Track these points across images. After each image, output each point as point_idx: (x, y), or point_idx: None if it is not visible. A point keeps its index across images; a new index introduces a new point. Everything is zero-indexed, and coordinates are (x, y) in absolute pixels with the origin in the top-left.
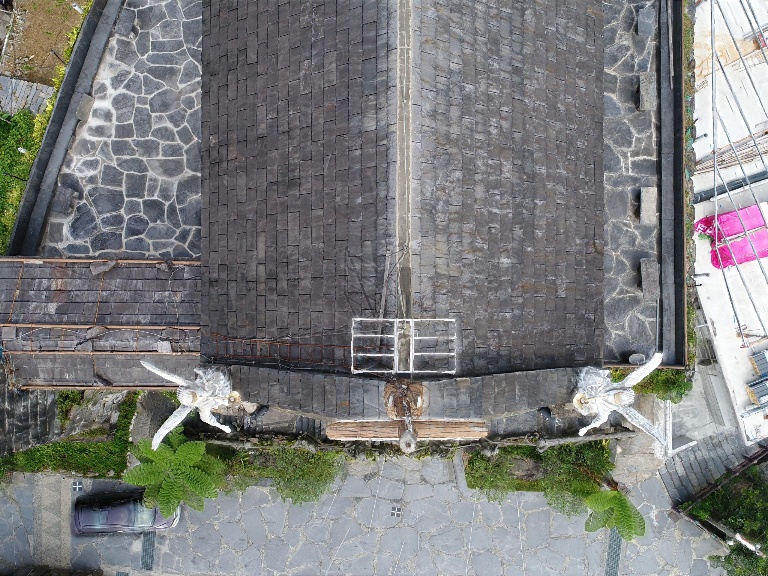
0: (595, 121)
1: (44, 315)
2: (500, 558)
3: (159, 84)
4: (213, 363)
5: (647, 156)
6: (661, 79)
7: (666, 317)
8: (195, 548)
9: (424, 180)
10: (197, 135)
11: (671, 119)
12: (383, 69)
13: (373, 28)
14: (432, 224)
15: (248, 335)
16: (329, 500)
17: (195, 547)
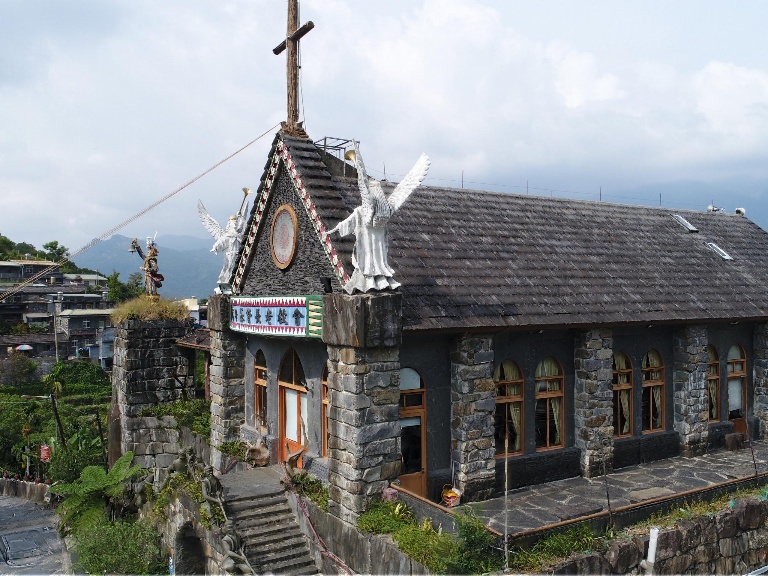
0: None
1: None
2: None
3: None
4: None
5: None
6: None
7: None
8: None
9: None
10: None
11: None
12: None
13: None
14: None
15: None
16: None
17: None
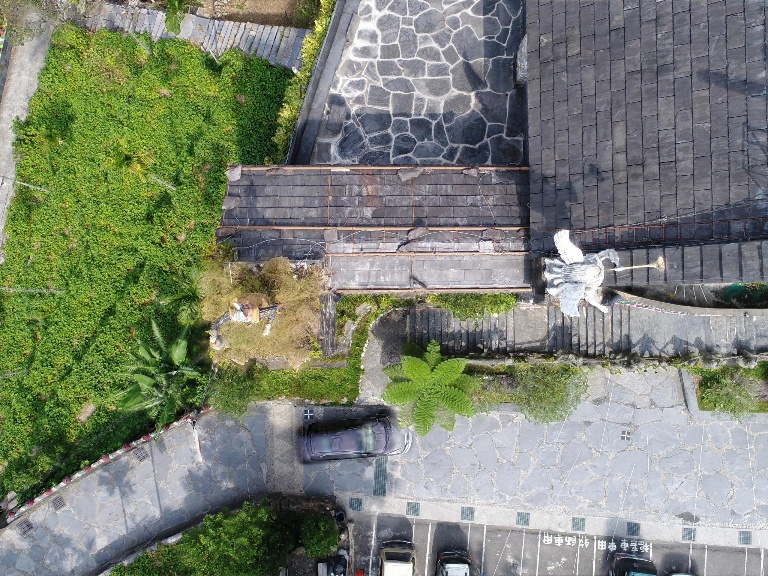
0: None
1: (361, 219)
2: (730, 479)
3: (424, 5)
4: None
5: None
6: None
7: None
8: (427, 473)
9: None
10: (462, 55)
11: None
12: None
13: None
14: None
15: (602, 224)
16: (559, 425)
17: (427, 472)
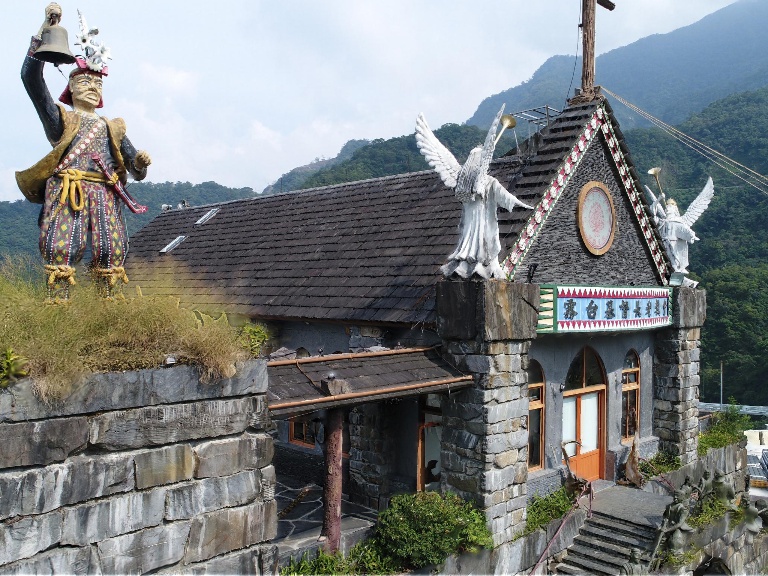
0: None
1: None
2: None
3: None
4: None
5: None
6: None
7: None
8: None
9: None
10: None
11: None
12: None
13: None
14: None
15: None
16: None
17: None
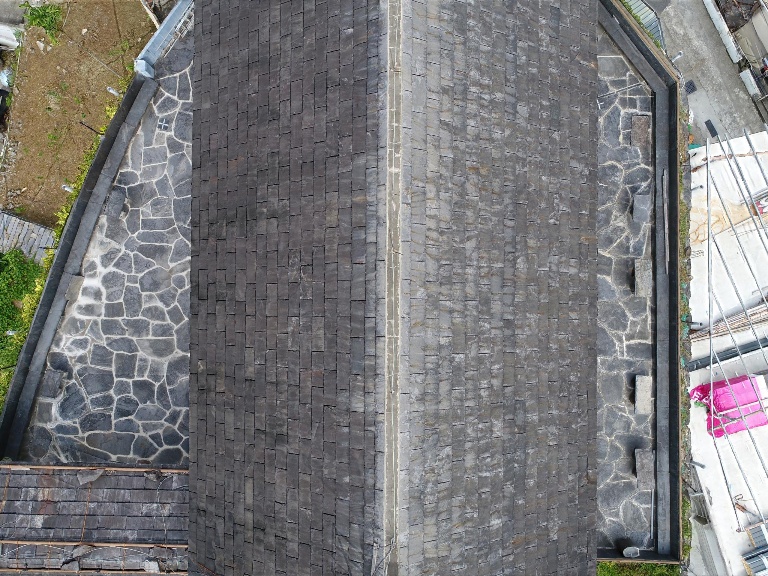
0: (588, 348)
1: (30, 529)
2: None
3: (149, 263)
4: None
5: (642, 340)
6: (656, 264)
7: (661, 506)
8: None
9: (412, 468)
10: (188, 315)
11: (666, 305)
12: (371, 353)
13: (361, 308)
14: (420, 510)
15: None
16: None
17: None
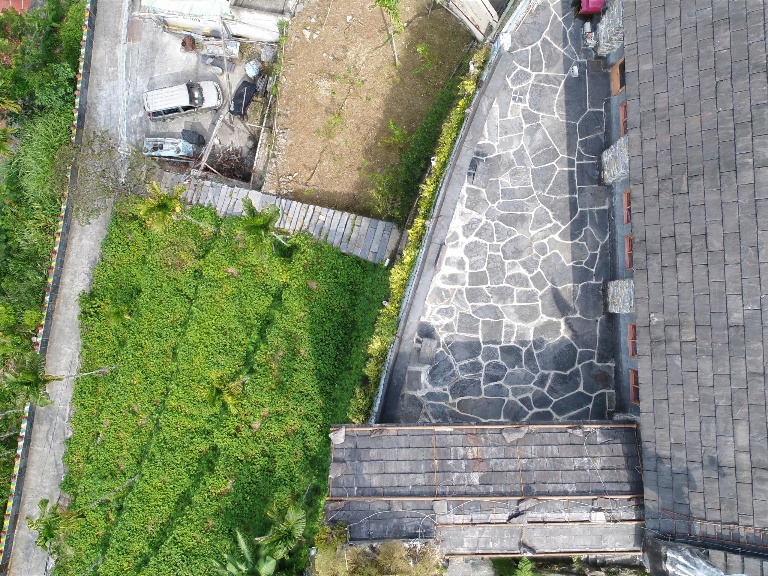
0: None
1: (470, 486)
2: None
3: (511, 231)
4: (671, 541)
5: None
6: None
7: None
8: None
9: None
10: (551, 280)
11: None
12: None
13: None
14: None
15: (725, 520)
16: None
17: None
